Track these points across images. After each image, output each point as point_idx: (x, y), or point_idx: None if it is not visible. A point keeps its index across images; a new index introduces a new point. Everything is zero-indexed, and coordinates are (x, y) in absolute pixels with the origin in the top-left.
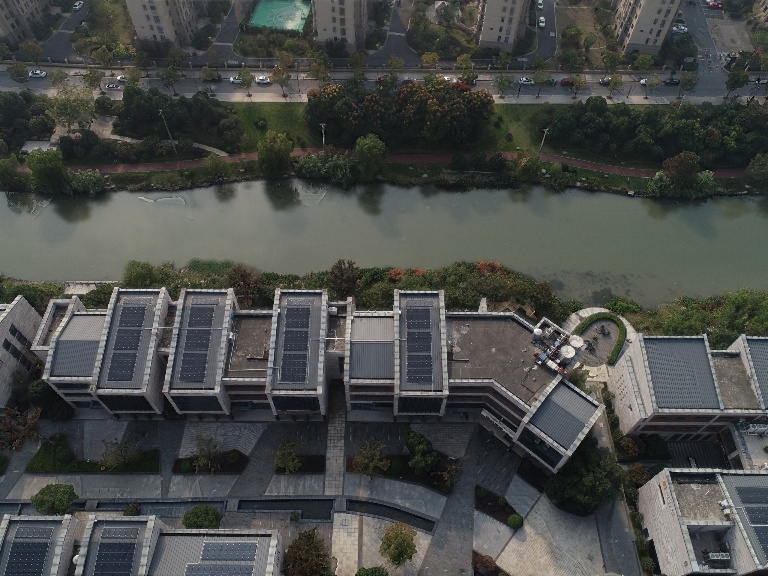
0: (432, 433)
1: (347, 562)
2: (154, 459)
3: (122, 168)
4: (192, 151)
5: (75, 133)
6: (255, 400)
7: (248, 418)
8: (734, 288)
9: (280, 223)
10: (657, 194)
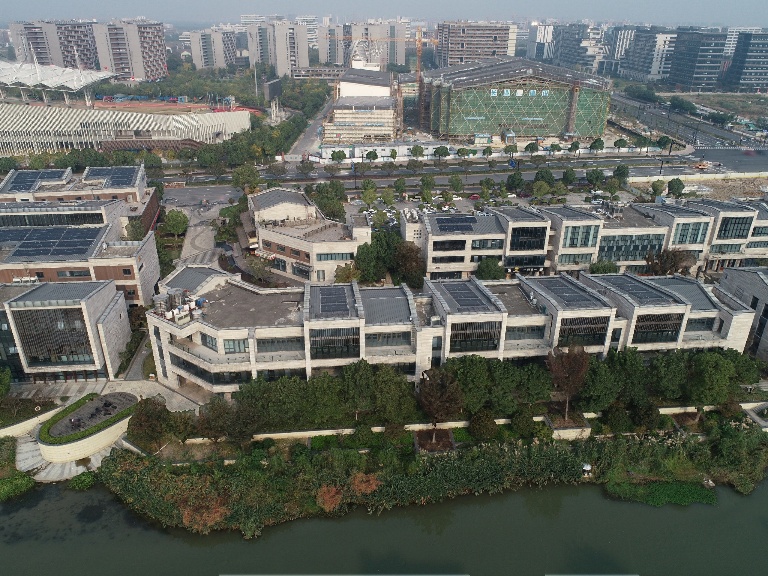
0: None
1: None
2: None
3: None
4: None
5: None
6: None
7: None
8: None
9: None
10: None
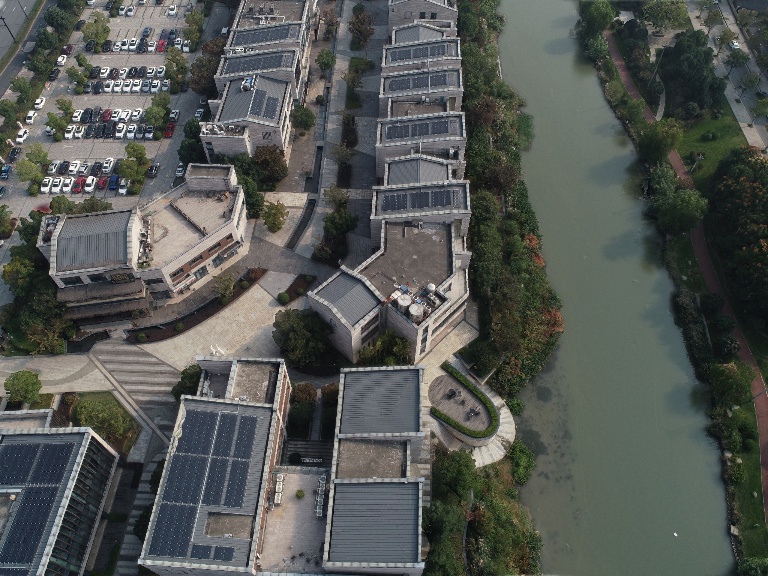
0: (364, 253)
1: (274, 200)
2: (354, 105)
3: (620, 63)
4: None
5: (649, 30)
6: None
7: None
8: None
9: (584, 165)
10: (740, 566)
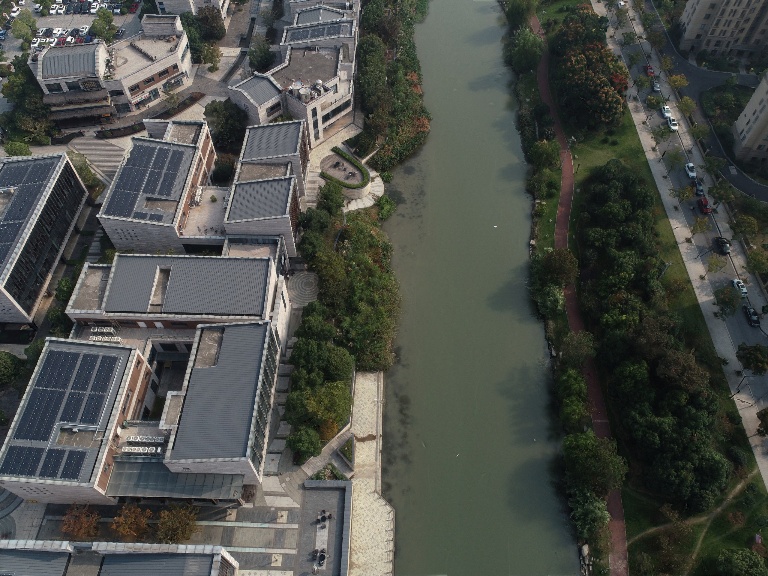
0: None
1: None
2: None
3: None
4: None
5: None
6: None
7: None
8: (406, 297)
9: (465, 32)
10: None
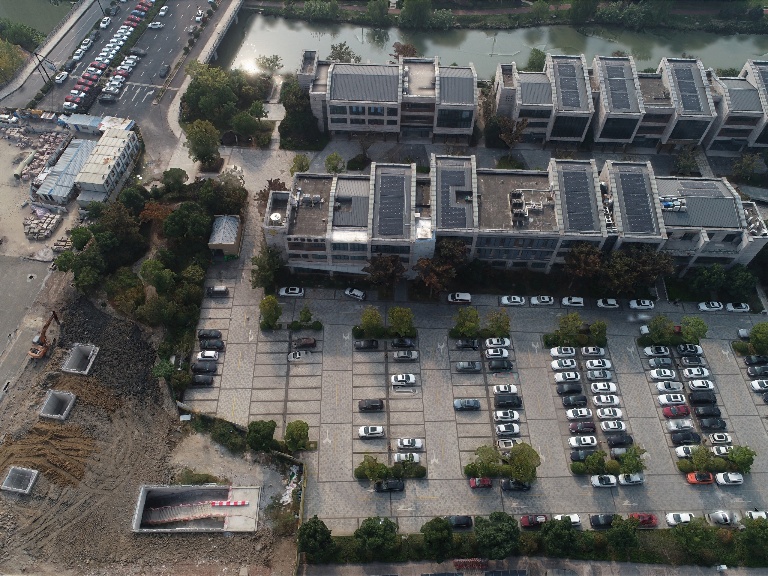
0: None
1: None
2: None
3: (462, 12)
4: (513, 2)
5: None
6: (648, 134)
7: (636, 152)
8: None
9: (596, 51)
10: None
